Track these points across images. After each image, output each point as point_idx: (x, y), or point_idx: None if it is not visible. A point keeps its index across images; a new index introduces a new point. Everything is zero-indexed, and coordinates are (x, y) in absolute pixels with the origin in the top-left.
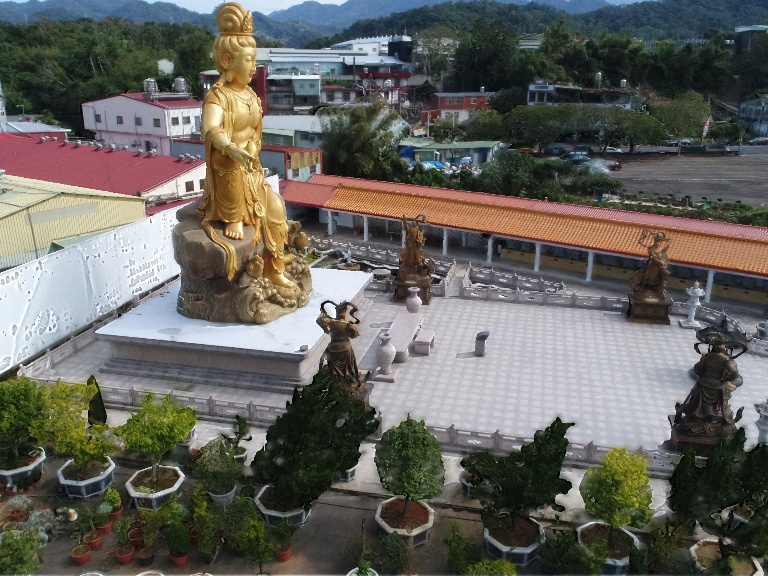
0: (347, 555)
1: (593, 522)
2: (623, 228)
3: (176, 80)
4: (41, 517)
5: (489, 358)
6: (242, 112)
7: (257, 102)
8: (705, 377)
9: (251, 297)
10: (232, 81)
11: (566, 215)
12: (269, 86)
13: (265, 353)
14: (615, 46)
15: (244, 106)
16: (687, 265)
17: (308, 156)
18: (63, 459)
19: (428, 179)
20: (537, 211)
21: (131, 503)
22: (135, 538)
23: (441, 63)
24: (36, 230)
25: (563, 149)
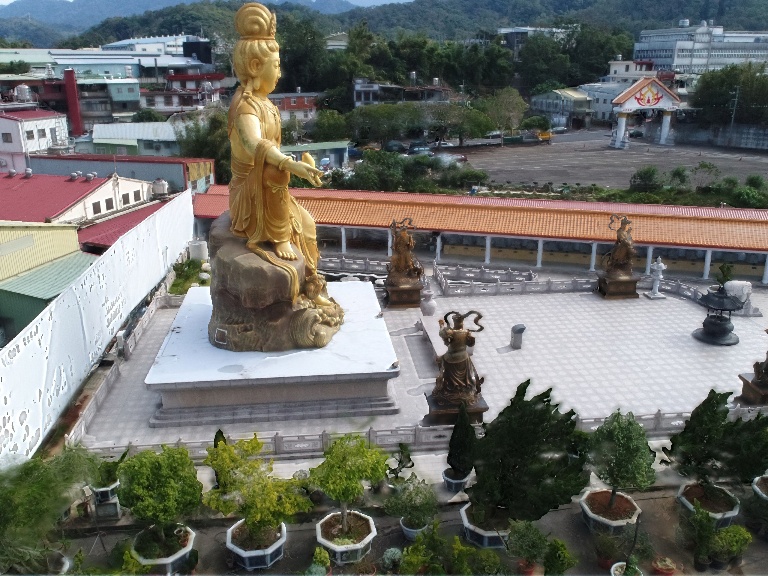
0: (579, 557)
1: (759, 477)
2: (566, 215)
3: (19, 87)
4: None
5: (528, 349)
6: (271, 122)
7: (276, 111)
8: None
9: (312, 320)
10: (258, 89)
11: (510, 208)
12: (80, 91)
13: (356, 376)
14: (414, 46)
15: (272, 116)
16: None
17: (203, 166)
18: (198, 531)
19: (299, 183)
20: (480, 206)
21: None
22: None
23: None
24: None
25: (402, 146)
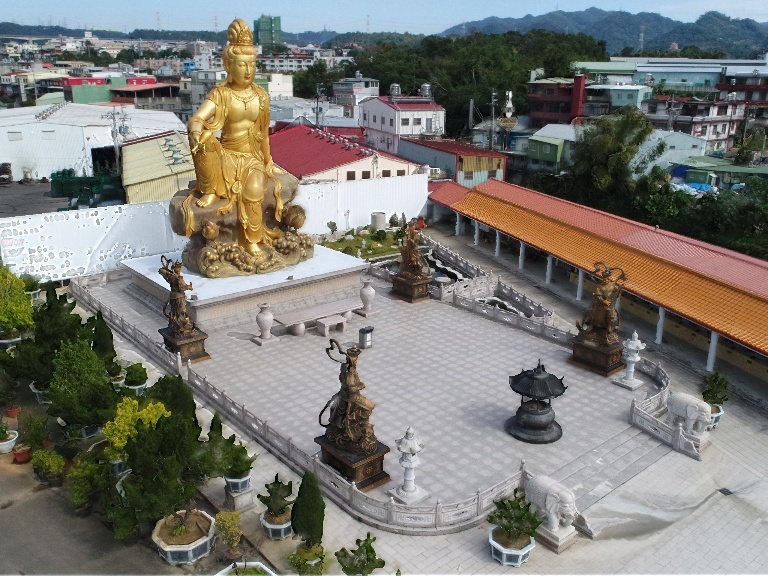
0: None
1: None
2: (657, 266)
3: (422, 86)
4: None
5: (365, 352)
6: (236, 107)
7: (259, 100)
8: None
9: (204, 254)
10: (233, 82)
11: (617, 243)
12: (586, 95)
13: None
14: None
15: (239, 102)
16: (688, 319)
17: (487, 161)
18: None
19: (668, 201)
20: (596, 235)
21: None
22: None
23: None
24: None
25: None
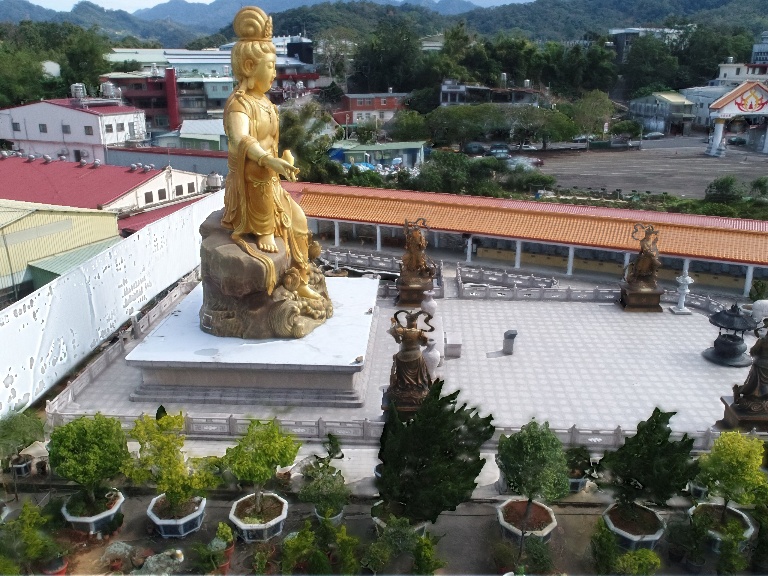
0: (481, 563)
1: (700, 503)
2: (600, 223)
3: (104, 85)
4: (160, 562)
5: (519, 356)
6: (264, 120)
7: (274, 109)
8: (762, 359)
9: (289, 311)
10: (253, 88)
11: (543, 213)
12: (179, 89)
13: (319, 367)
14: (511, 47)
15: (266, 114)
16: (665, 255)
17: None
18: (135, 498)
19: (366, 181)
20: (514, 210)
21: (237, 536)
22: (264, 572)
23: (346, 64)
24: (11, 252)
25: (482, 148)
